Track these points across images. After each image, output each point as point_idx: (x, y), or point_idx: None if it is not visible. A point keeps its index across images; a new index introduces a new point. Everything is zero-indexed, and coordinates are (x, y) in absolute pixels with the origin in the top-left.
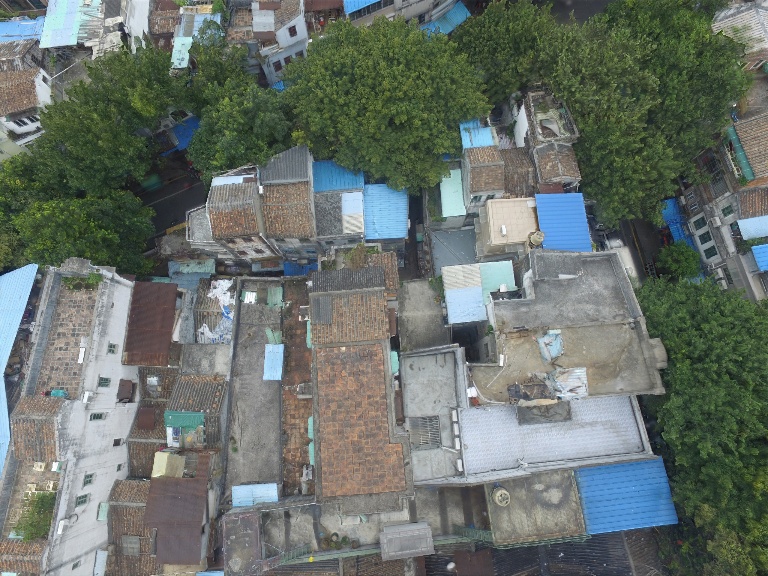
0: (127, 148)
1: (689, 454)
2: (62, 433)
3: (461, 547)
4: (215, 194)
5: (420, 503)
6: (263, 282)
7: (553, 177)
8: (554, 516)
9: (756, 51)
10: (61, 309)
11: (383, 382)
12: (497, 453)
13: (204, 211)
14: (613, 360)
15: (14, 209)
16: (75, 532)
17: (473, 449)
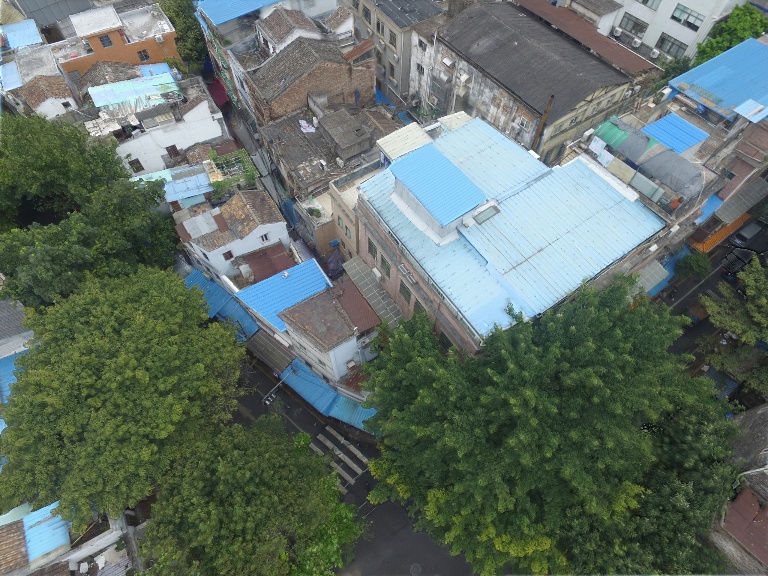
0: None
1: None
2: None
3: None
4: None
5: None
6: None
7: None
8: None
9: None
10: None
11: None
12: None
13: None
14: None
15: None
16: None
17: None
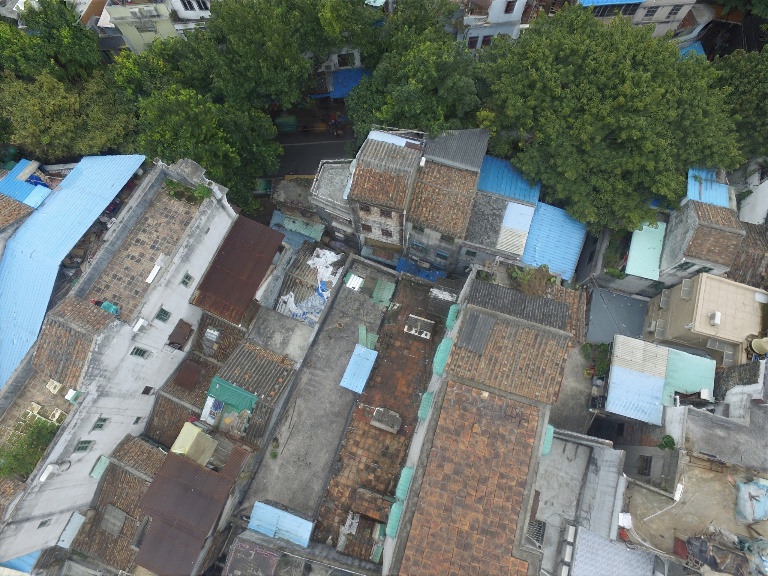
0: (292, 63)
1: None
2: (95, 358)
3: None
4: (370, 147)
5: None
6: (375, 270)
7: None
8: None
9: None
10: (151, 213)
11: (527, 463)
12: None
13: (340, 167)
14: None
15: (144, 93)
16: (60, 483)
17: None
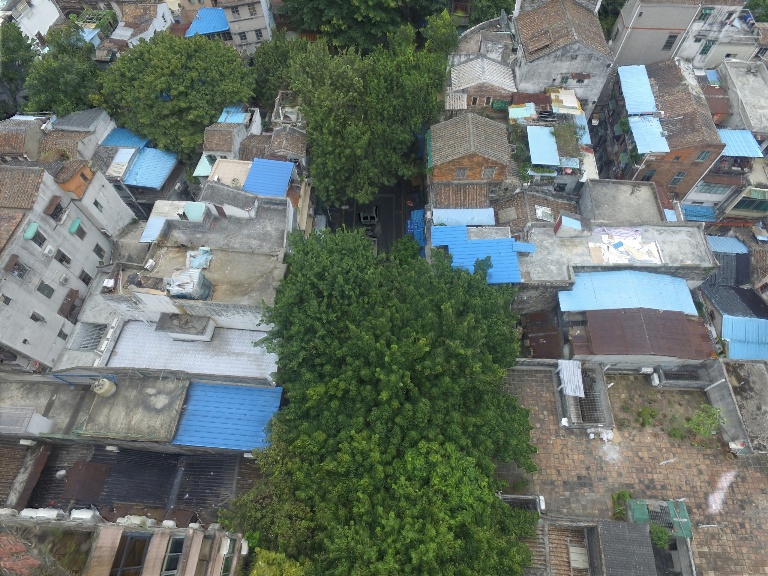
0: None
1: (287, 375)
2: None
3: (81, 458)
4: (4, 122)
5: (58, 403)
6: None
7: (277, 149)
8: (150, 419)
9: (475, 86)
10: None
11: (7, 238)
12: (140, 364)
13: None
14: (249, 282)
15: None
16: None
17: (121, 357)
